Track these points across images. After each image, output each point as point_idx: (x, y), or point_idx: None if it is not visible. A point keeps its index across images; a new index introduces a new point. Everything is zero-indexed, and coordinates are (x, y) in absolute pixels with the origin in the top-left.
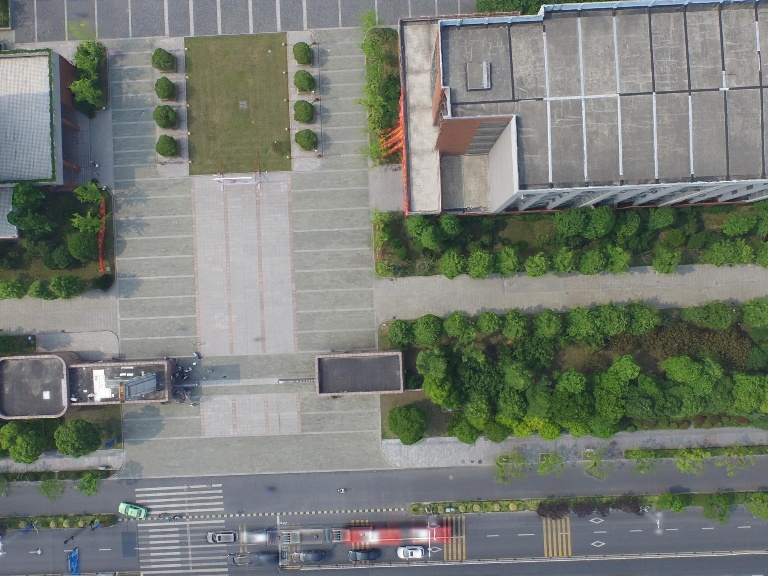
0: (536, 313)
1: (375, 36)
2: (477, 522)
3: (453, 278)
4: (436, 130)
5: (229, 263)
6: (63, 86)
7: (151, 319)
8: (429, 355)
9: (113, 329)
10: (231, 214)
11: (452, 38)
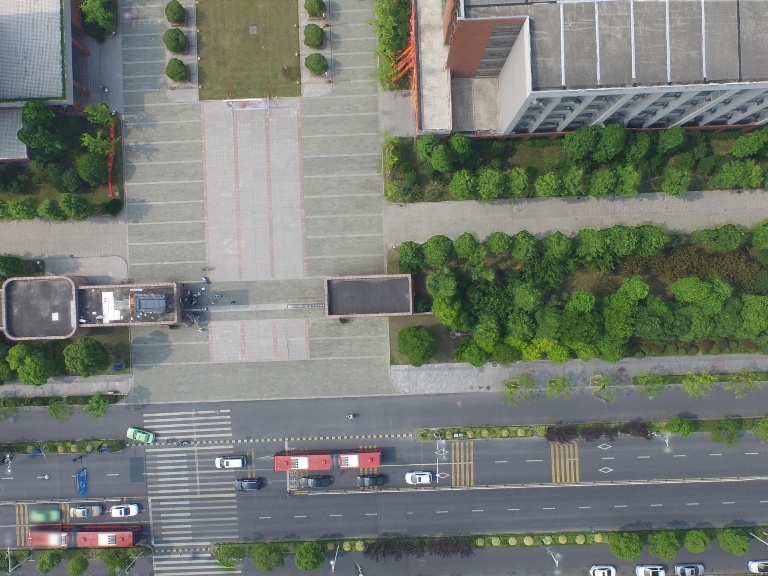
0: None
1: None
2: (485, 448)
3: (462, 203)
4: (447, 49)
5: (238, 188)
6: (73, 7)
7: (160, 244)
8: (439, 275)
9: (122, 254)
10: (240, 139)
11: None
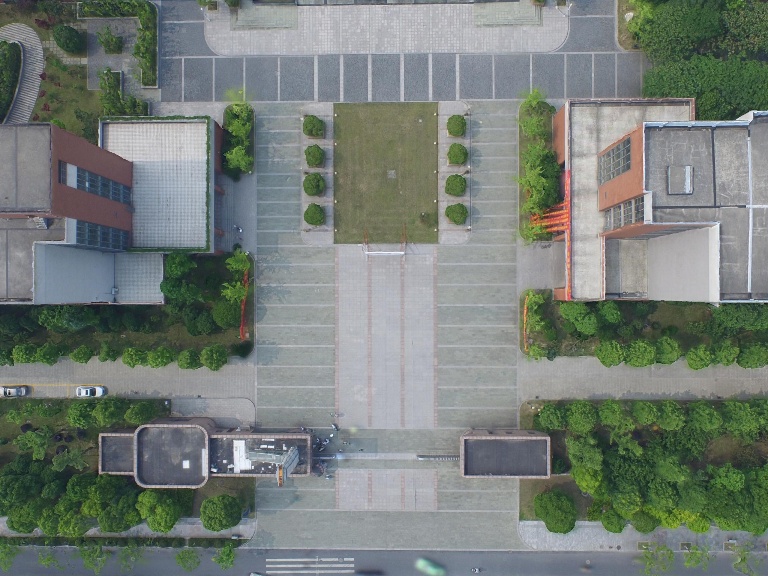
0: (683, 399)
1: (529, 110)
2: None
3: None
4: (601, 215)
5: (371, 335)
6: (216, 152)
7: (289, 388)
8: (583, 444)
9: (250, 396)
10: (375, 285)
11: (653, 139)
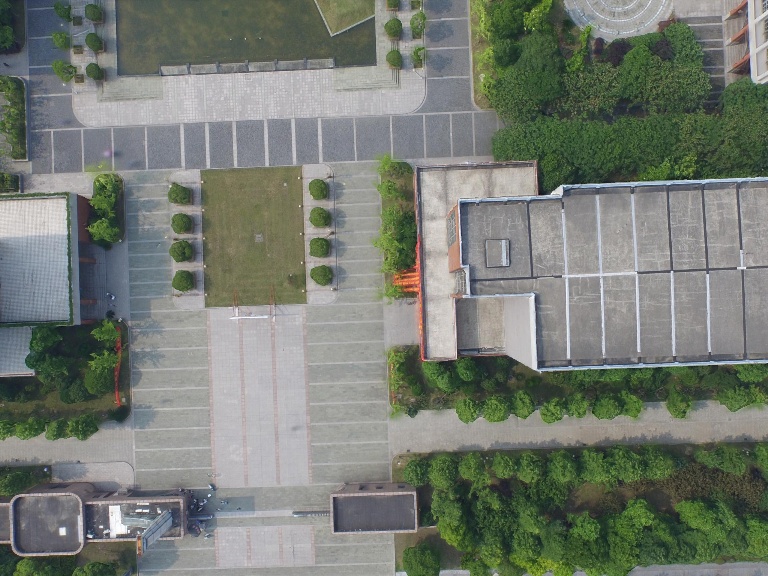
0: (550, 447)
1: (390, 170)
2: None
3: None
4: (452, 276)
5: (244, 395)
6: (80, 225)
7: (166, 450)
8: (444, 499)
9: (128, 460)
10: (246, 346)
11: (471, 214)
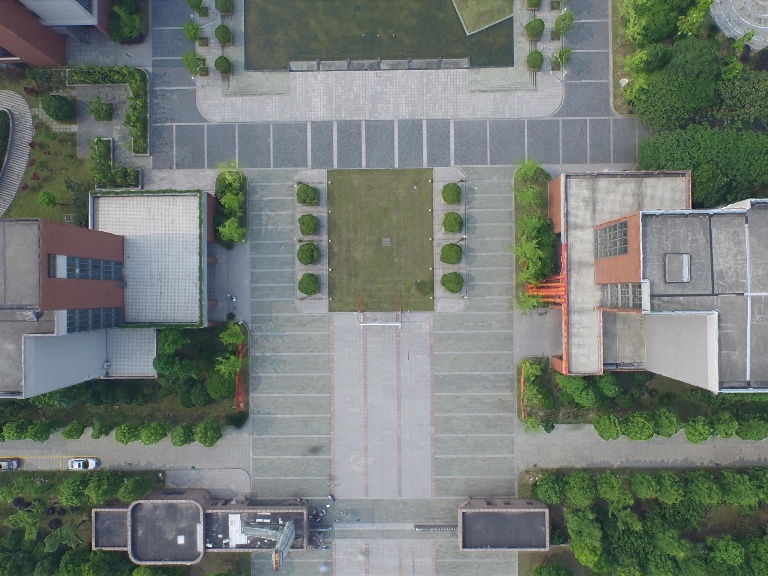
0: (682, 466)
1: (525, 176)
2: None
3: None
4: (598, 288)
5: (367, 404)
6: (209, 224)
7: (285, 458)
8: (582, 518)
9: (245, 467)
10: (370, 353)
11: (650, 226)
